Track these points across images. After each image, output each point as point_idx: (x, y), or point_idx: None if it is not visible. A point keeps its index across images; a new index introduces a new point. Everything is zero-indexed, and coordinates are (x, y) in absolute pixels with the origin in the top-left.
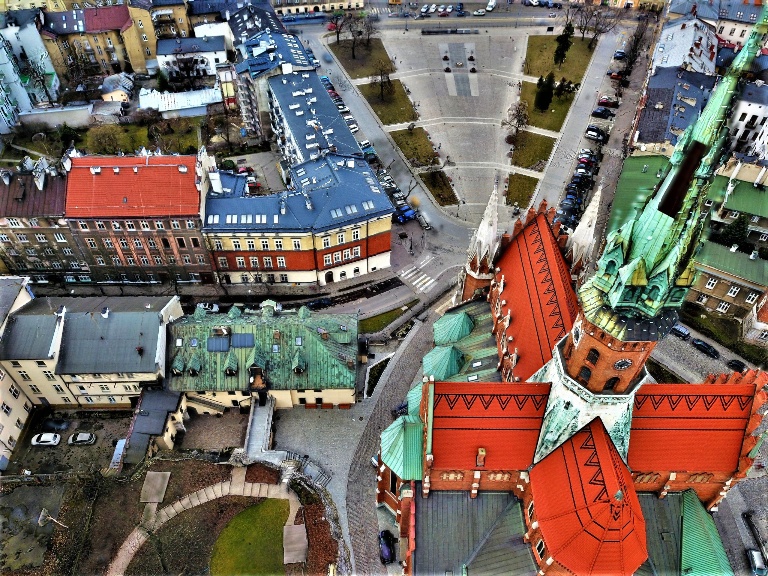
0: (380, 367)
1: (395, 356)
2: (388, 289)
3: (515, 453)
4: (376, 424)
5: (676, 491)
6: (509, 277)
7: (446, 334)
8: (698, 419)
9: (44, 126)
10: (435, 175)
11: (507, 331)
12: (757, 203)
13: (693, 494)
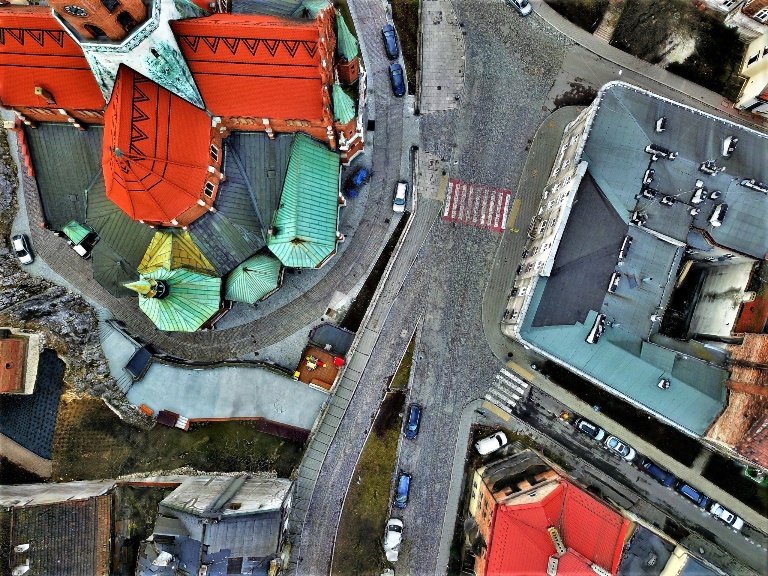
0: None
1: None
2: None
3: (83, 93)
4: None
5: (288, 132)
6: None
7: None
8: (265, 65)
9: None
10: None
11: None
12: None
13: (300, 136)
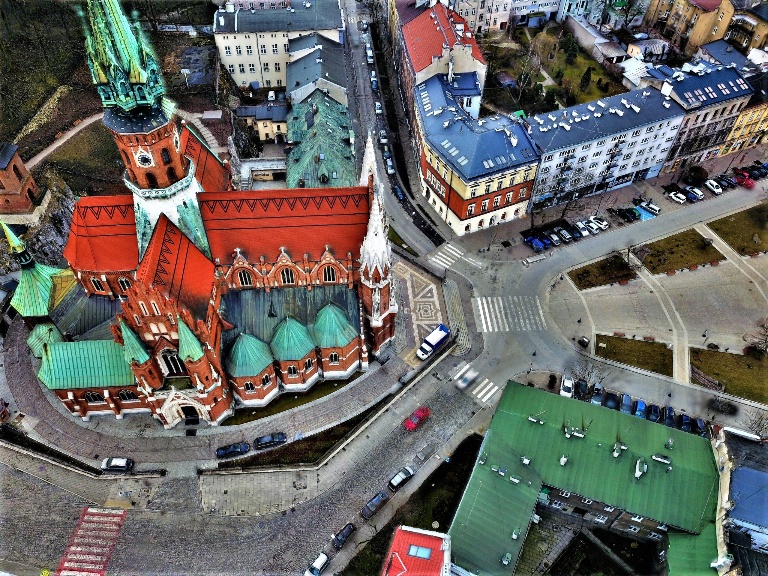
0: None
1: None
2: (427, 235)
3: None
4: None
5: None
6: None
7: None
8: None
9: (571, 31)
10: (626, 270)
11: None
12: None
13: None
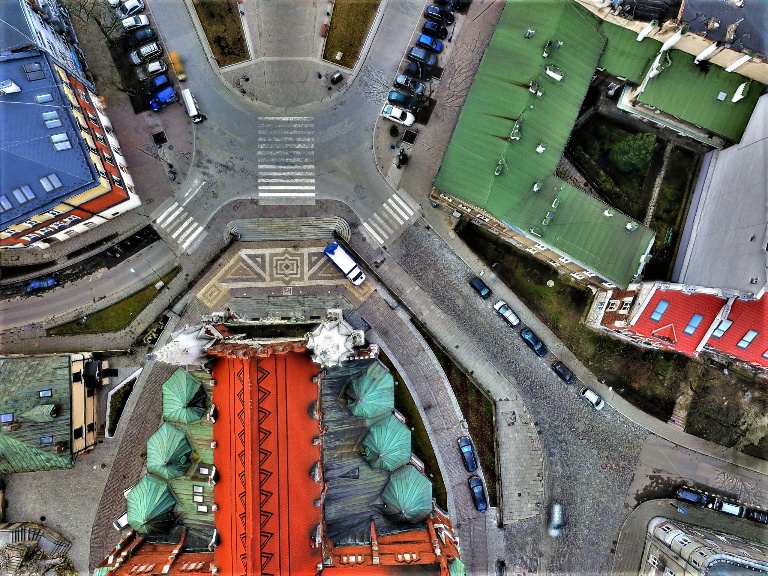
0: (123, 395)
1: (143, 374)
2: (137, 250)
3: None
4: (120, 473)
5: None
6: (220, 409)
7: (174, 412)
8: None
9: None
10: None
11: (214, 489)
12: (687, 96)
13: None
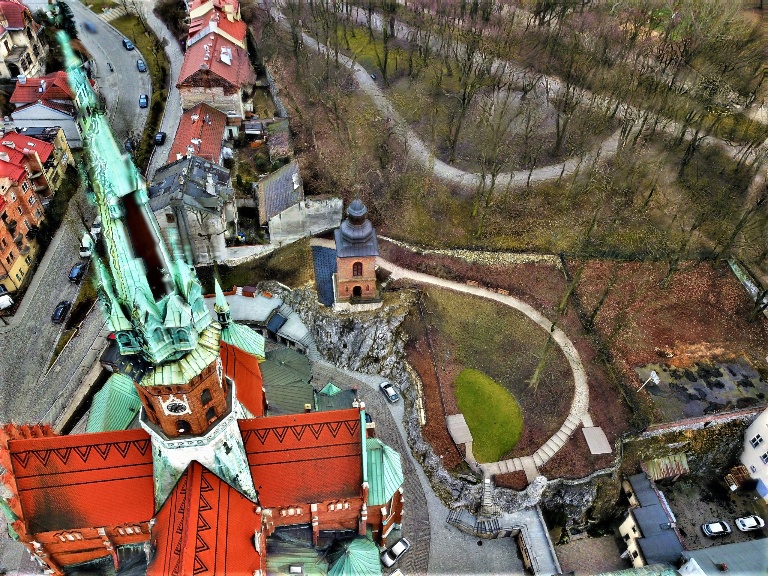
0: None
1: None
2: None
3: None
4: None
5: None
6: None
7: None
8: None
9: None
10: None
11: None
12: None
13: None
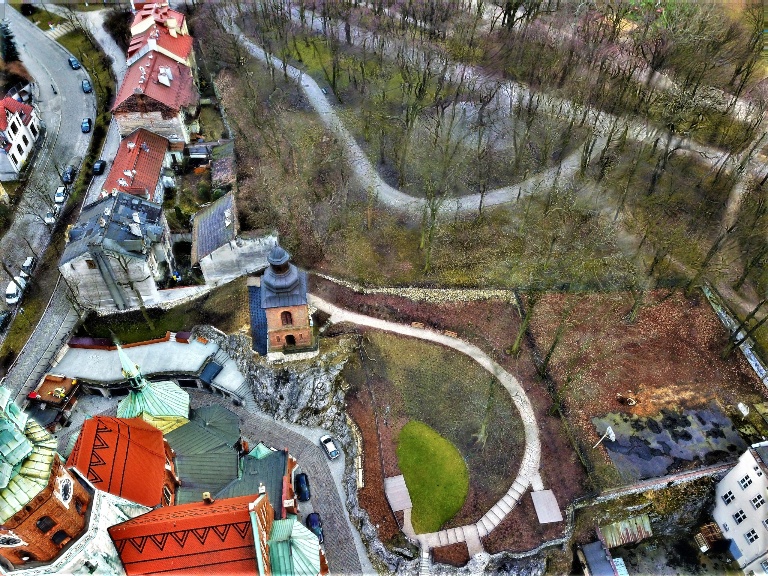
0: None
1: None
2: None
3: None
4: None
5: None
6: None
7: None
8: None
9: None
10: None
11: None
12: None
13: None
